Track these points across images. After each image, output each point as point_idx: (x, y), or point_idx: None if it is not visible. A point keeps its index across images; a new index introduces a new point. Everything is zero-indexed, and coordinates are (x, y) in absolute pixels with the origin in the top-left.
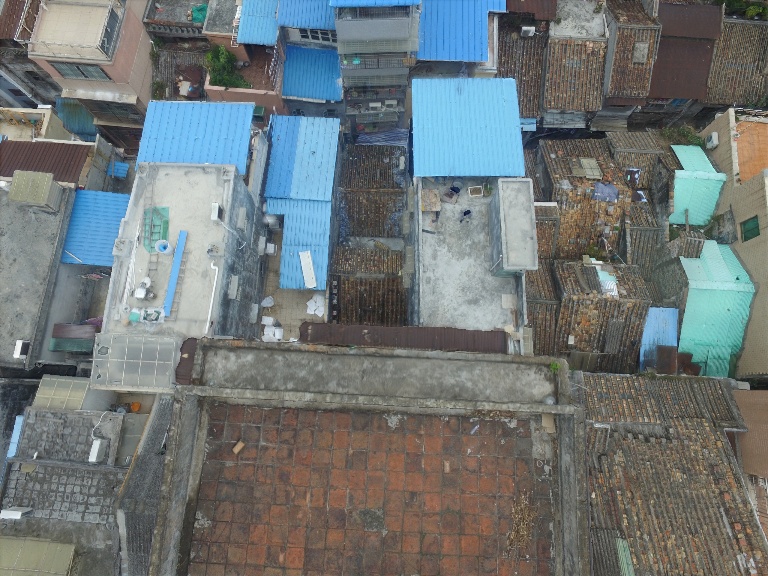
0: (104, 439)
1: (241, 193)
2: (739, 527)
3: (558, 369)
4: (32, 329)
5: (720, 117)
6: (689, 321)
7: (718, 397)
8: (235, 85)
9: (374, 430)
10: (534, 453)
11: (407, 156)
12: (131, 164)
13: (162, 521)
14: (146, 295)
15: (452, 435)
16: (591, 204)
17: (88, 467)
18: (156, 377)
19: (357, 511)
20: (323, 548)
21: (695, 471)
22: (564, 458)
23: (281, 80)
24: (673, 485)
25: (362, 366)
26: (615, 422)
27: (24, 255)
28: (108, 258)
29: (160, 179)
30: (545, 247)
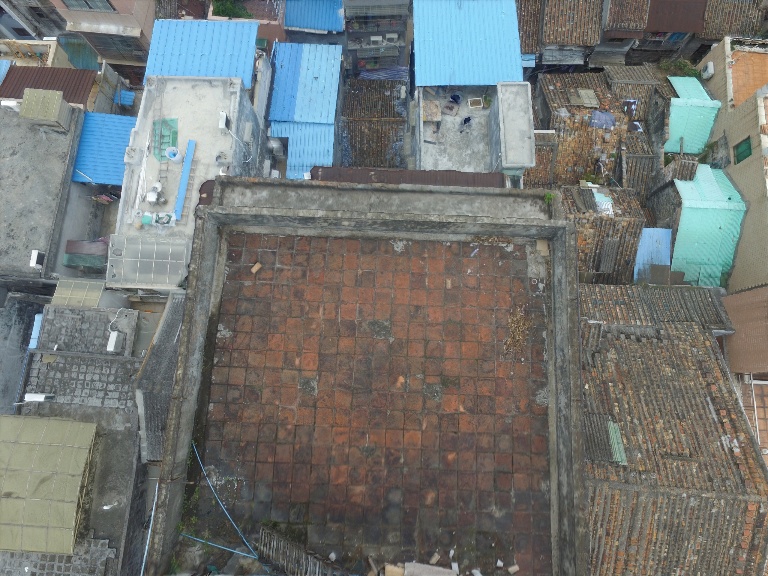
0: (121, 333)
1: (247, 109)
2: (724, 413)
3: (552, 199)
4: (46, 242)
5: (716, 47)
6: (682, 240)
7: (708, 304)
8: (238, 15)
9: (381, 254)
10: (529, 273)
11: (408, 82)
12: (137, 94)
13: (189, 319)
14: (157, 199)
15: (453, 257)
16: (588, 131)
17: (106, 356)
18: (169, 275)
19: (366, 322)
20: (335, 353)
21: (684, 366)
22: (557, 273)
23: (283, 10)
24: (663, 378)
25: (370, 200)
26: (608, 325)
27: (36, 172)
28: (118, 177)
29: (168, 92)
30: (543, 173)
